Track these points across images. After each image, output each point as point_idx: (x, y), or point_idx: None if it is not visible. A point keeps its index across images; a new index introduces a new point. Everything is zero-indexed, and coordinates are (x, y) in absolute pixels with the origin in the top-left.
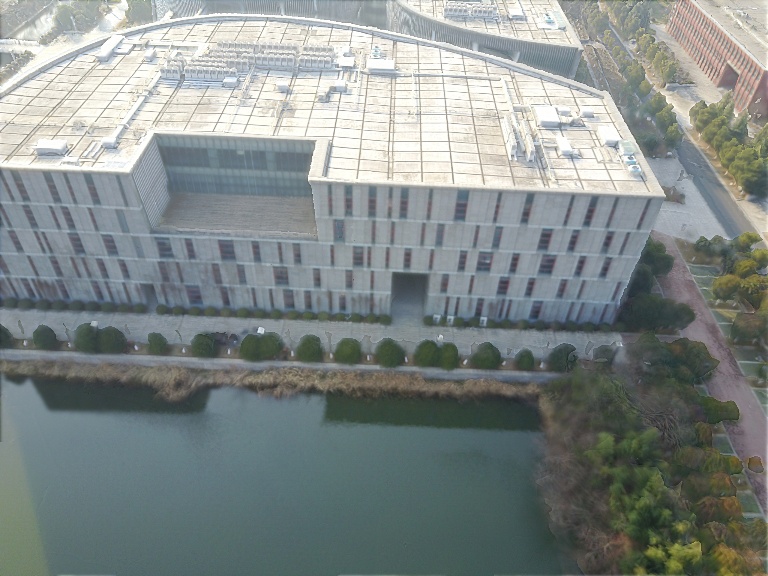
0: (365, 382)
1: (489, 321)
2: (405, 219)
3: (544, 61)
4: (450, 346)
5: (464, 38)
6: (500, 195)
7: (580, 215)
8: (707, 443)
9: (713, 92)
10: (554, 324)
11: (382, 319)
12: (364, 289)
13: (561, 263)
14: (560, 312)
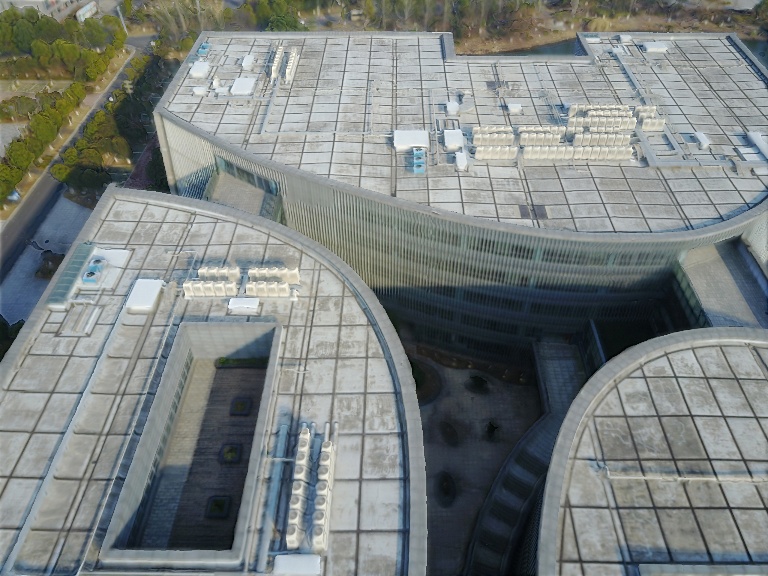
0: None
1: None
2: None
3: None
4: None
5: None
6: None
7: None
8: None
9: None
10: None
11: None
12: None
13: None
14: None
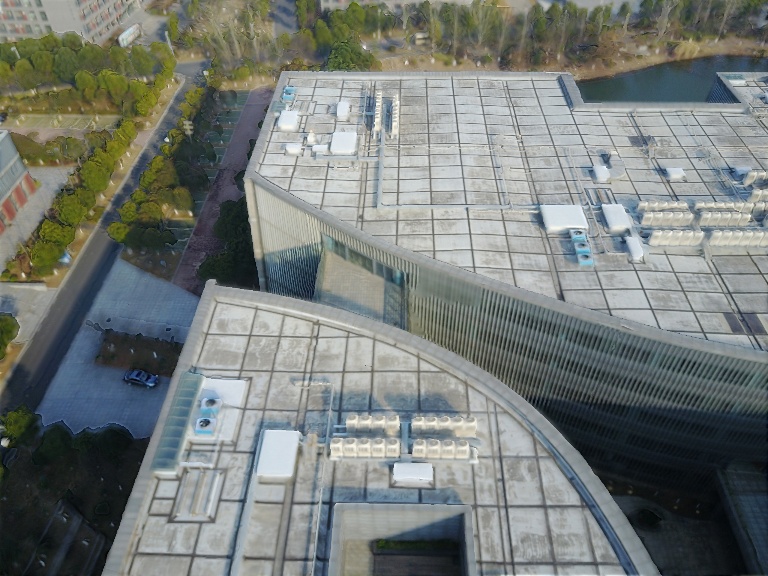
0: None
1: None
2: None
3: None
4: None
5: None
6: None
7: None
8: None
9: None
10: None
11: None
12: None
13: None
14: None
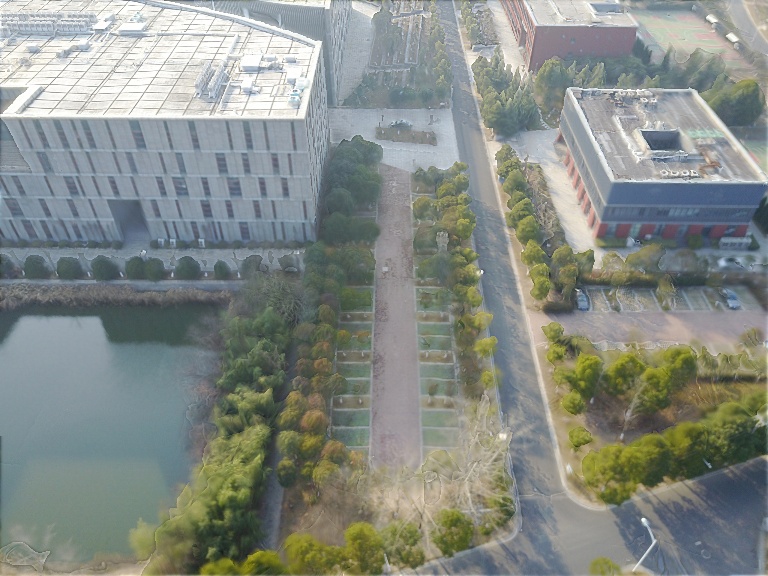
0: (79, 293)
1: (207, 242)
2: (96, 149)
3: (301, 21)
4: (155, 261)
5: (234, 4)
6: (166, 124)
7: (240, 139)
8: (325, 321)
9: (513, 51)
10: (263, 243)
11: (113, 244)
12: (90, 217)
13: (245, 185)
14: (266, 232)
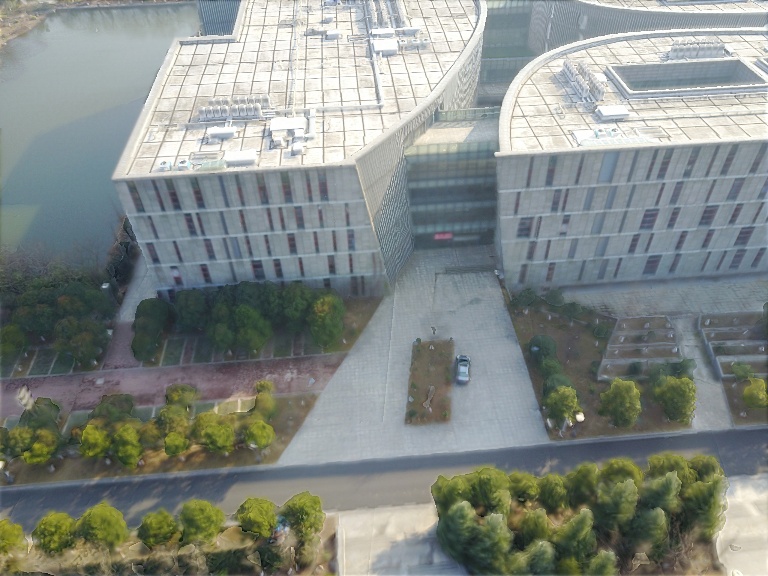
0: None
1: None
2: None
3: None
4: None
5: None
6: None
7: None
8: None
9: None
10: None
11: None
12: None
13: None
14: None
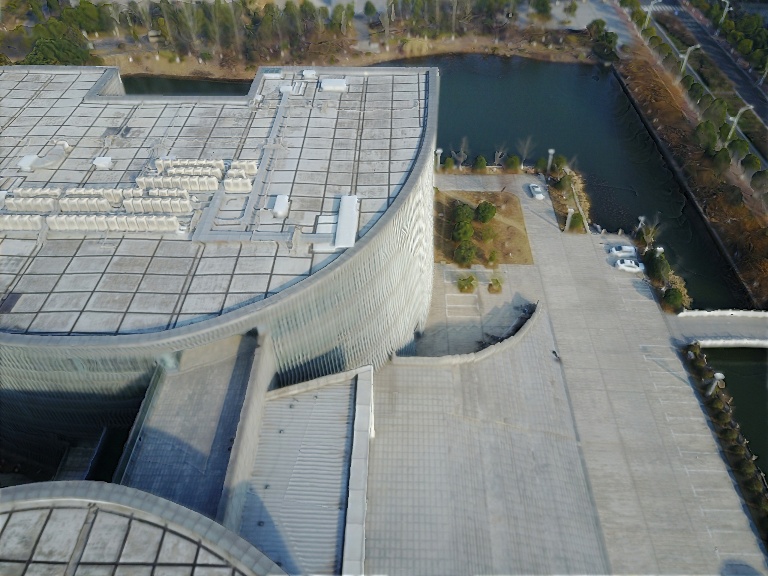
0: None
1: None
2: None
3: None
4: None
5: None
6: None
7: None
8: None
9: None
10: None
11: None
12: None
13: None
14: None
